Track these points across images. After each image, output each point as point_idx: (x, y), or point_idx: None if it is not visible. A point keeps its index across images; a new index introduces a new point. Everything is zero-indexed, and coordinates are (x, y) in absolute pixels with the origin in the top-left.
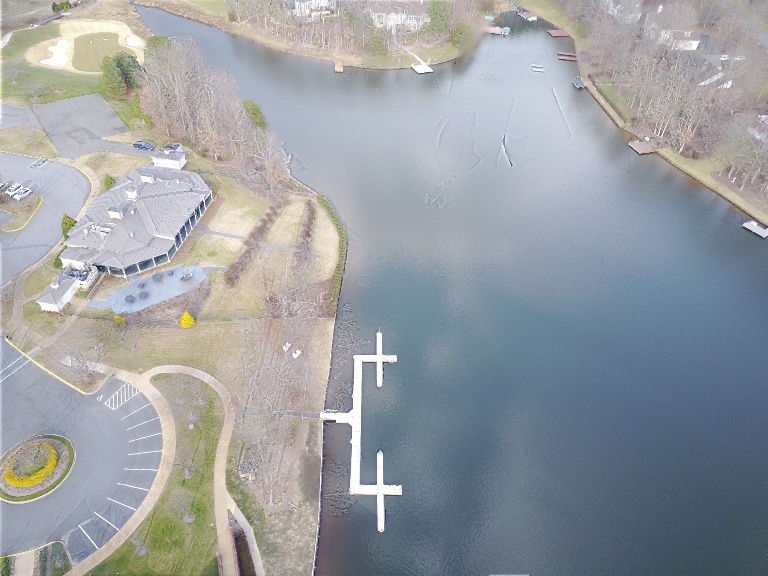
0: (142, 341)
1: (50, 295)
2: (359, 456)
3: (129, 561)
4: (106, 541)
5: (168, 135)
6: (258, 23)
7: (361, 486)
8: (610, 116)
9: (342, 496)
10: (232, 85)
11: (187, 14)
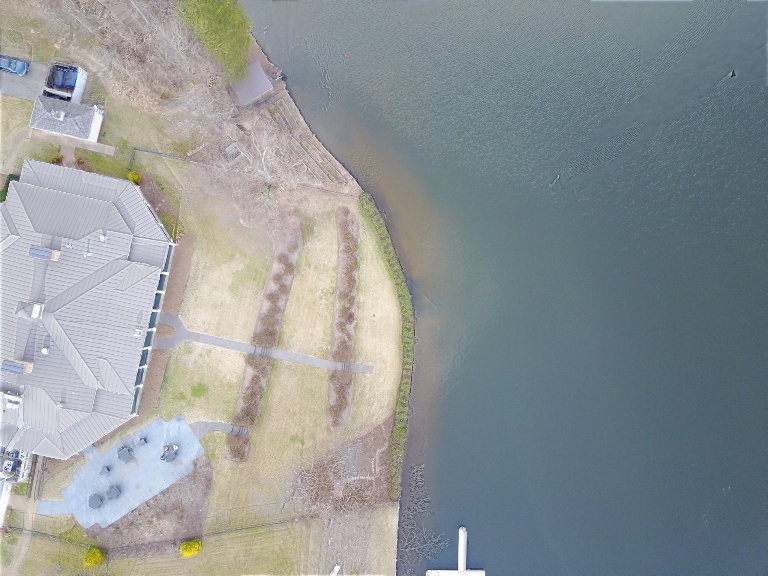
0: None
1: None
2: None
3: None
4: None
5: None
6: None
7: None
8: None
9: None
10: None
11: None
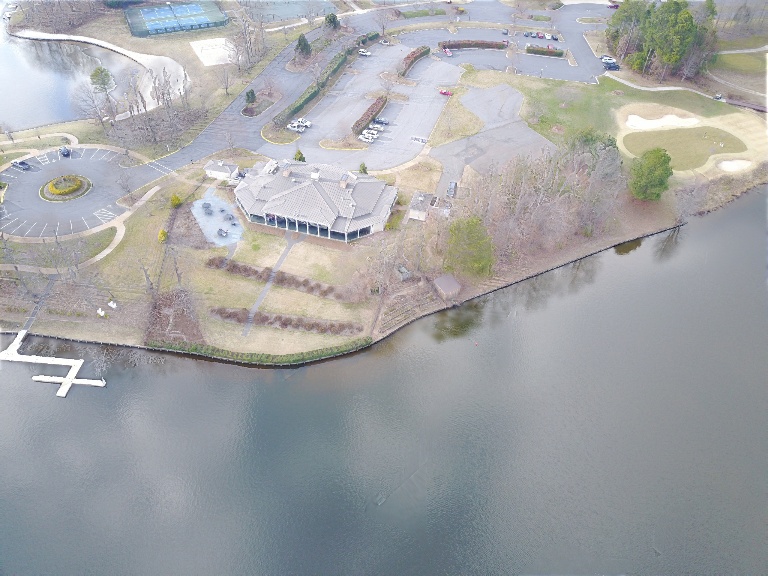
0: (156, 218)
1: (212, 163)
2: None
3: None
4: None
5: None
6: None
7: None
8: None
9: None
10: None
11: None
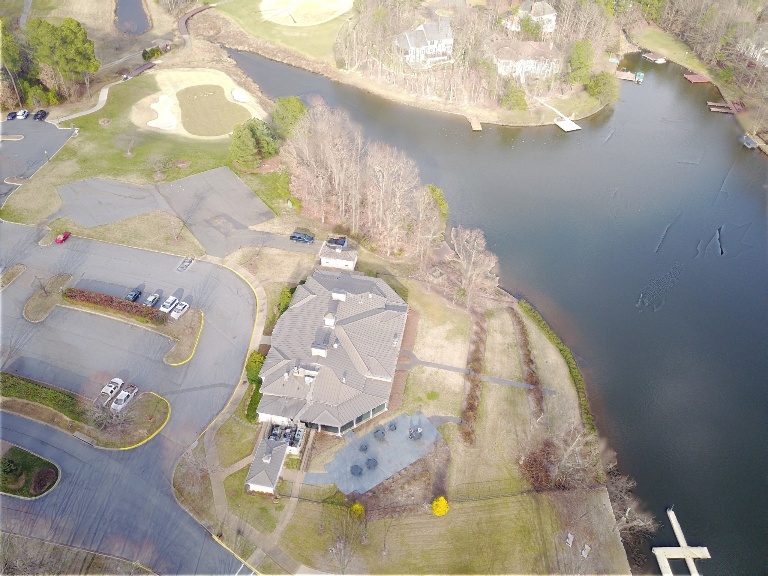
0: (391, 539)
1: (264, 473)
2: None
3: None
4: None
5: (323, 221)
6: (371, 71)
7: None
8: None
9: None
10: (410, 168)
11: (287, 60)
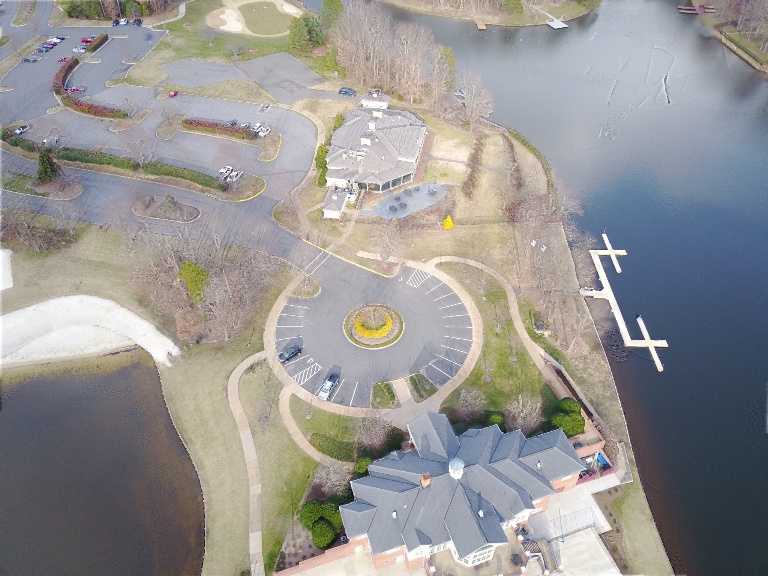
0: (416, 239)
1: (334, 204)
2: (623, 320)
3: (481, 385)
4: (455, 373)
5: (362, 84)
6: None
7: (633, 341)
8: (745, 60)
9: (618, 349)
10: (427, 35)
11: None
